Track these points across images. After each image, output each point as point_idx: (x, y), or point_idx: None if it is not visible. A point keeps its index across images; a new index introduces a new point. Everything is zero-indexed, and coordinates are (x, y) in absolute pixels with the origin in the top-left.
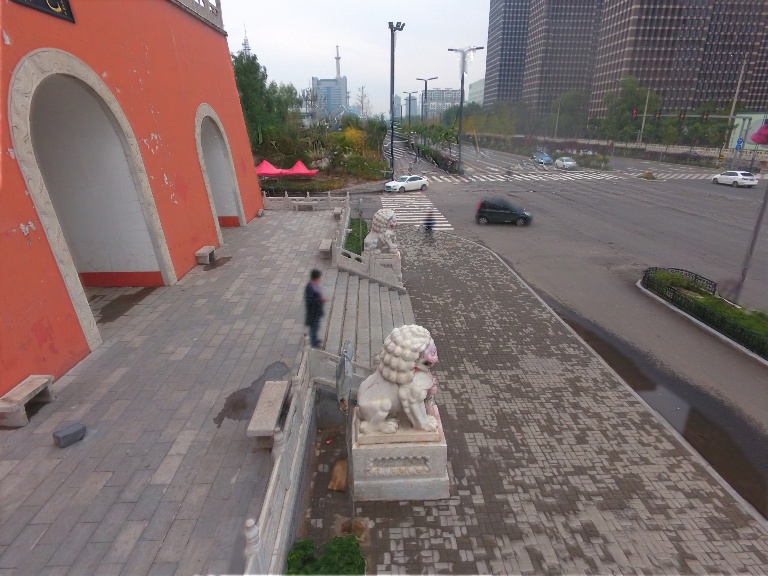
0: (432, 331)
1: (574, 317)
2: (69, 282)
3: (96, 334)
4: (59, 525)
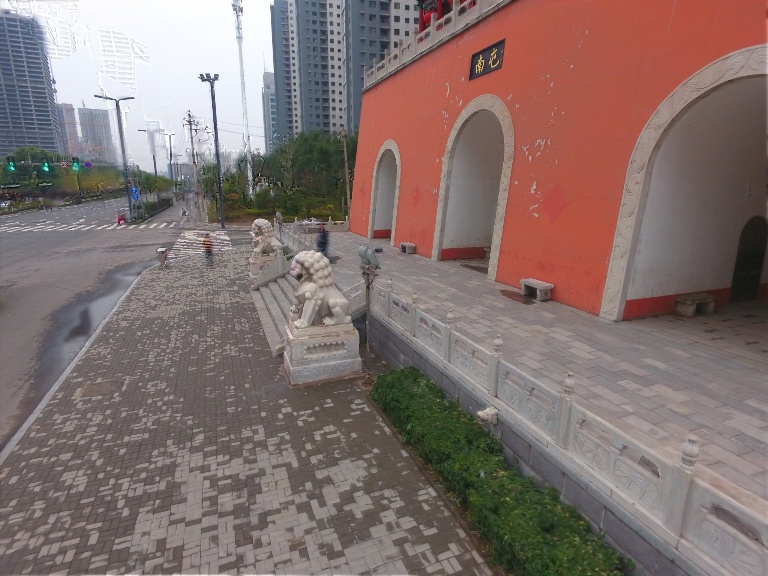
0: (246, 320)
1: (58, 355)
2: None
3: None
4: None
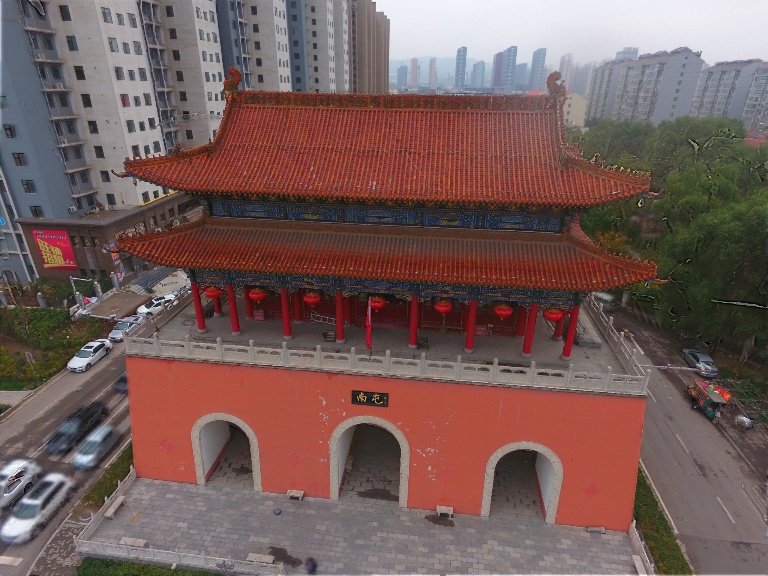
0: None
1: None
2: (333, 478)
3: (336, 496)
4: (245, 522)
